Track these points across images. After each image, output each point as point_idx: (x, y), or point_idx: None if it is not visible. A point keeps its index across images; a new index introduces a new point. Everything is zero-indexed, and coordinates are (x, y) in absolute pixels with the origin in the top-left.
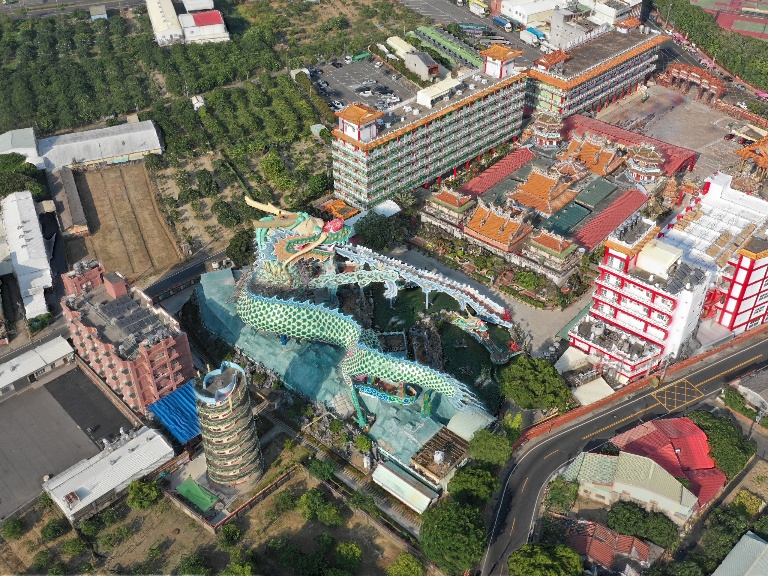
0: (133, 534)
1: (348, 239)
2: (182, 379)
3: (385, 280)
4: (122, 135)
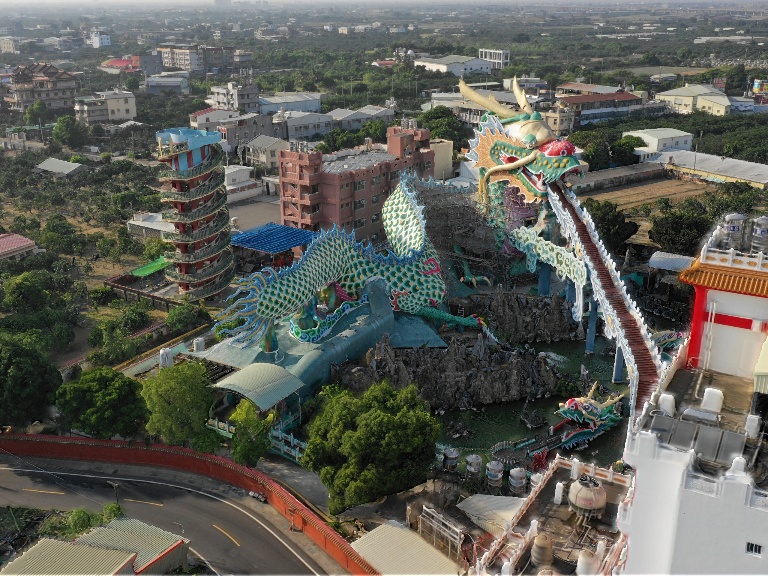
0: (120, 265)
1: (558, 176)
2: (309, 221)
3: (576, 279)
4: (751, 163)
